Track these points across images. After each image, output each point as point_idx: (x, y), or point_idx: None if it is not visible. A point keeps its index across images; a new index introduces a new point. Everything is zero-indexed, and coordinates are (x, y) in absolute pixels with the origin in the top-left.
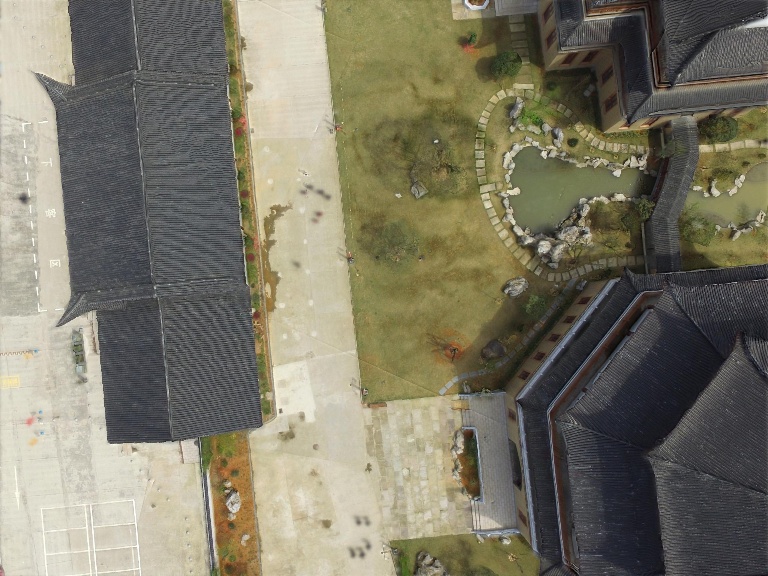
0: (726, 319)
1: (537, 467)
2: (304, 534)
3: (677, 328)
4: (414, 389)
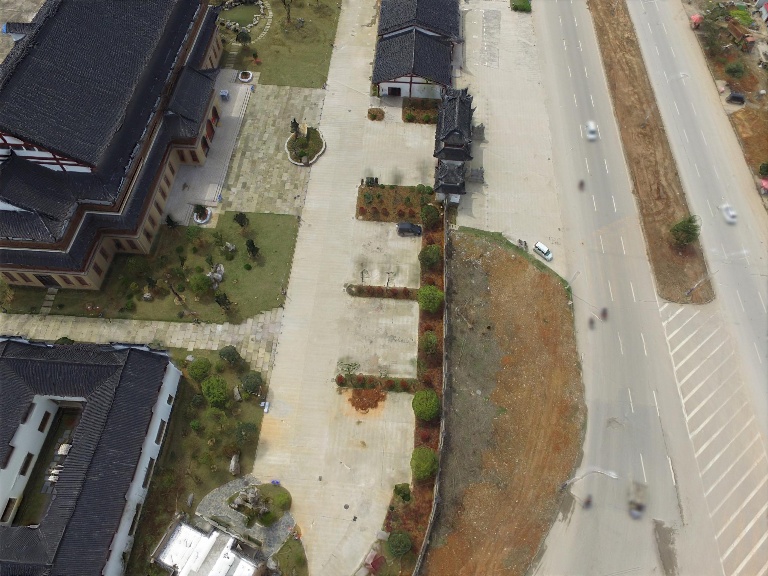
0: None
1: None
2: None
3: None
4: None
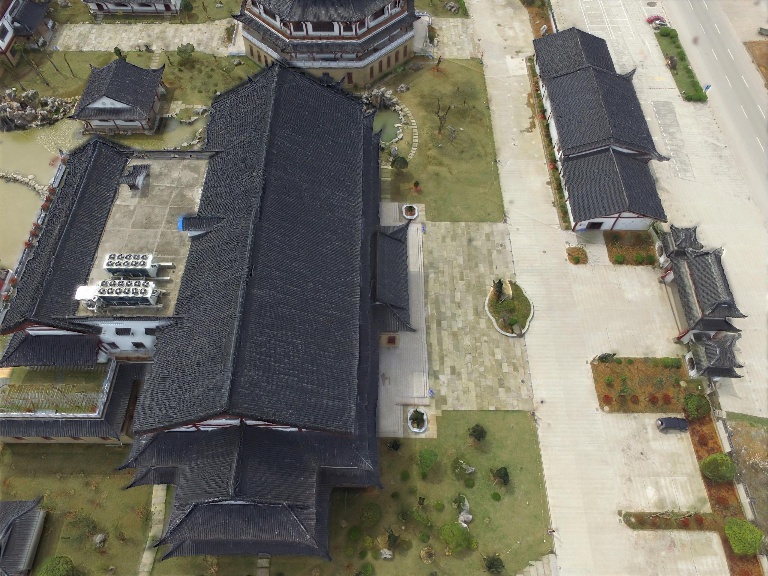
0: (338, 7)
1: (413, 1)
2: (510, 23)
3: (359, 7)
4: (456, 62)
